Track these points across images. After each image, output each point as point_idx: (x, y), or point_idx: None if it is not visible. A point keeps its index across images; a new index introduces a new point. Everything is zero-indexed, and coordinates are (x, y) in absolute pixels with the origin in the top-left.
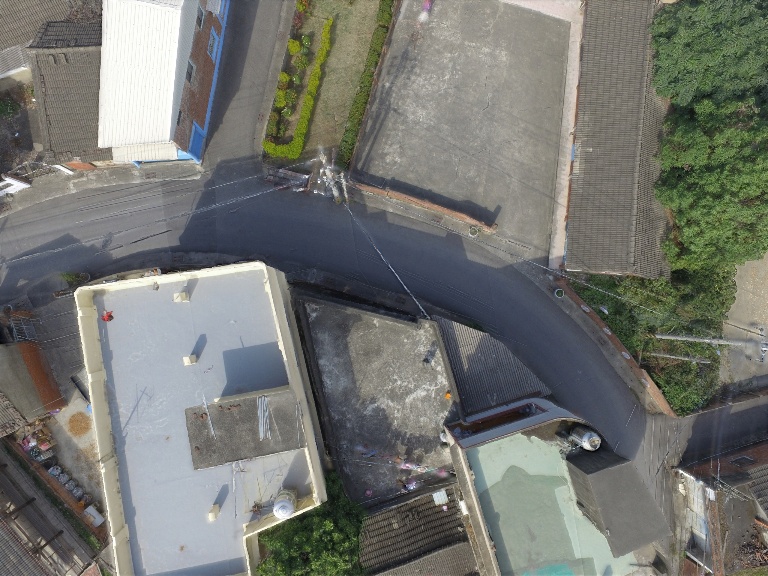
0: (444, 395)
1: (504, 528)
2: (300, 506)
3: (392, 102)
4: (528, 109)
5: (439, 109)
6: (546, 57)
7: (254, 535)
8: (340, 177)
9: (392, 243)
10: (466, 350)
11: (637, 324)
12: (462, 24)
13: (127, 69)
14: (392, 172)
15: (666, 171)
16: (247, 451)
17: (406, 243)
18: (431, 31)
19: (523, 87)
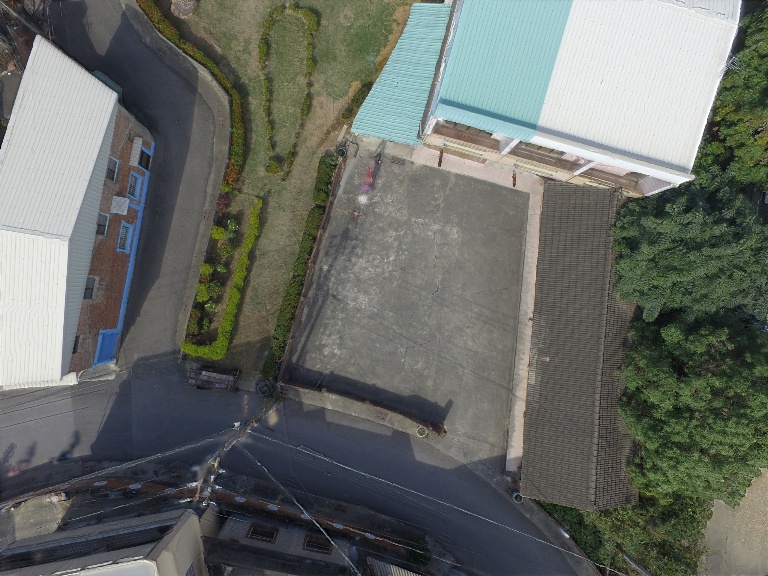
0: None
1: None
2: None
3: (331, 287)
4: (482, 291)
5: (383, 294)
6: (502, 233)
7: None
8: None
9: (331, 445)
10: None
11: None
12: (409, 198)
13: (5, 311)
14: (331, 365)
15: (631, 390)
16: None
17: (347, 444)
18: (374, 207)
19: (477, 267)
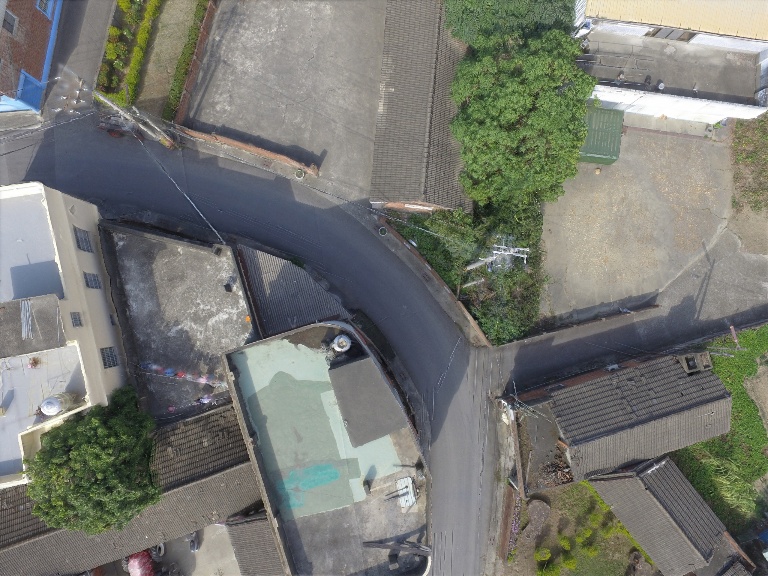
0: (245, 318)
1: (271, 430)
2: (73, 407)
3: (222, 54)
4: (352, 59)
5: (267, 60)
6: (370, 10)
7: (37, 437)
8: (135, 112)
9: (223, 186)
10: (269, 277)
11: (453, 258)
12: None
13: None
14: (222, 120)
15: (458, 106)
16: (10, 350)
17: (236, 186)
18: None
19: (347, 38)
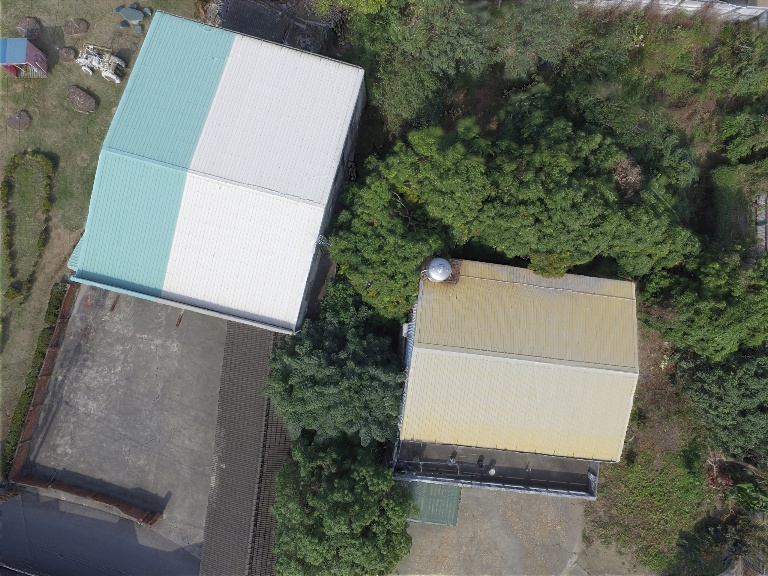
0: None
1: None
2: None
3: (64, 395)
4: (199, 397)
5: (110, 401)
6: (218, 345)
7: None
8: None
9: (63, 531)
10: None
11: None
12: (135, 317)
13: None
14: (63, 463)
15: None
16: None
17: (77, 531)
18: (104, 324)
19: (194, 376)
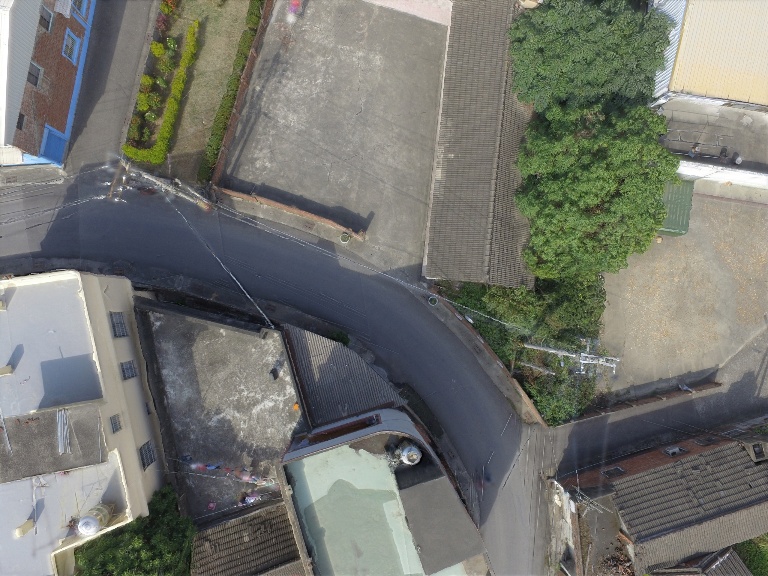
0: (293, 406)
1: (330, 543)
2: (113, 521)
3: (263, 106)
4: (403, 114)
5: (311, 113)
6: (422, 61)
7: (70, 551)
8: (178, 183)
9: (262, 249)
10: (318, 360)
11: (508, 333)
12: (336, 27)
13: None
14: (262, 177)
15: (524, 178)
16: (46, 466)
17: (276, 249)
18: (304, 34)
19: (398, 92)
